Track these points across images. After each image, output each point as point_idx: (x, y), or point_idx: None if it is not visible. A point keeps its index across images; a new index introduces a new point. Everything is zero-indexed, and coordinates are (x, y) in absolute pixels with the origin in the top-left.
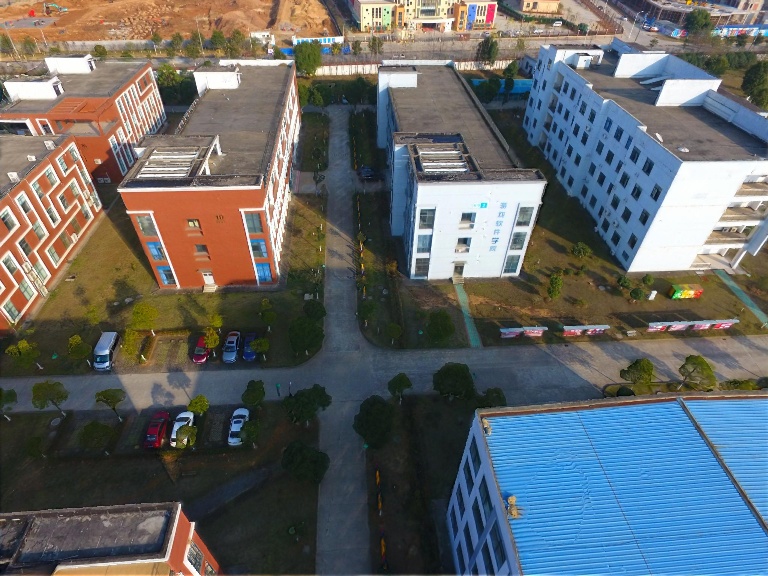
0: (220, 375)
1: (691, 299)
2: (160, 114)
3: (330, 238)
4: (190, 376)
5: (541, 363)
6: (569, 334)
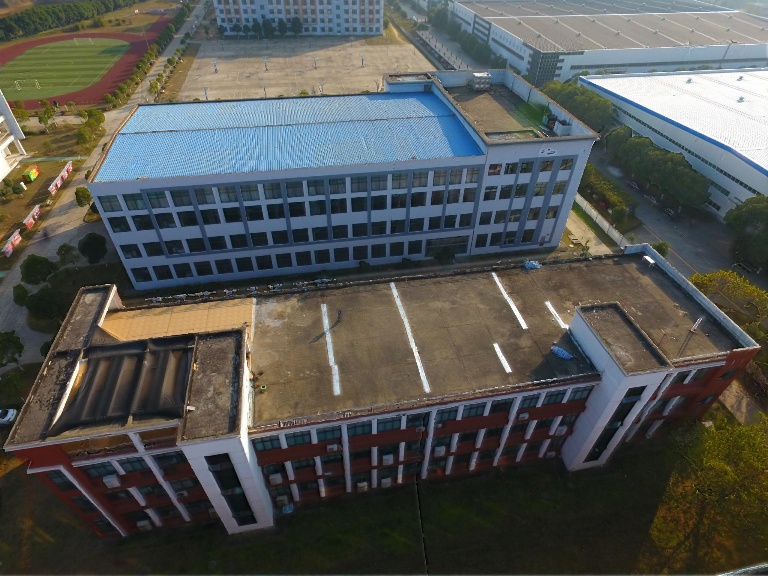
0: None
1: (39, 175)
2: None
3: None
4: None
5: (46, 244)
6: (30, 226)
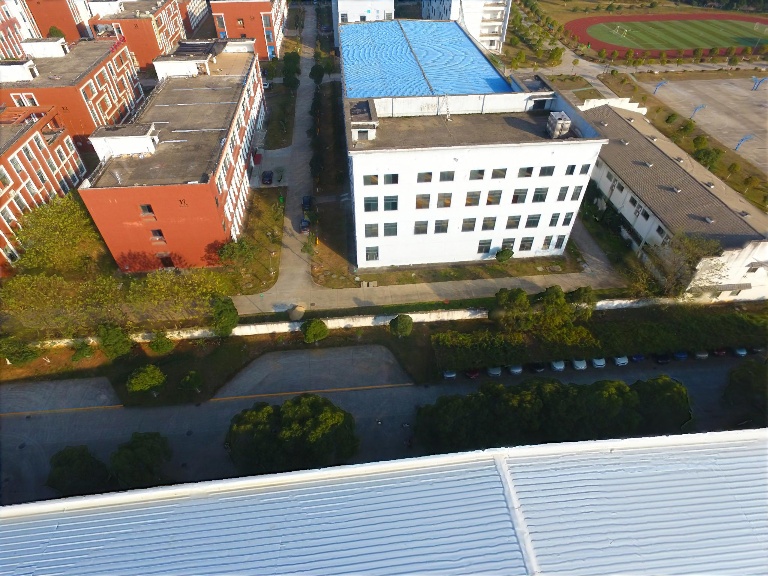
0: None
1: None
2: (205, 6)
3: (303, 49)
4: None
5: None
6: None
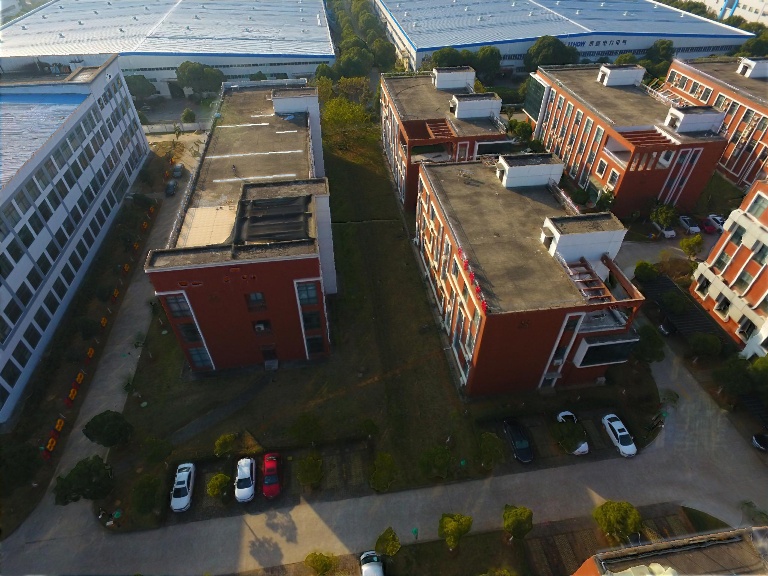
0: (211, 567)
1: None
2: None
3: None
4: (252, 561)
5: None
6: None
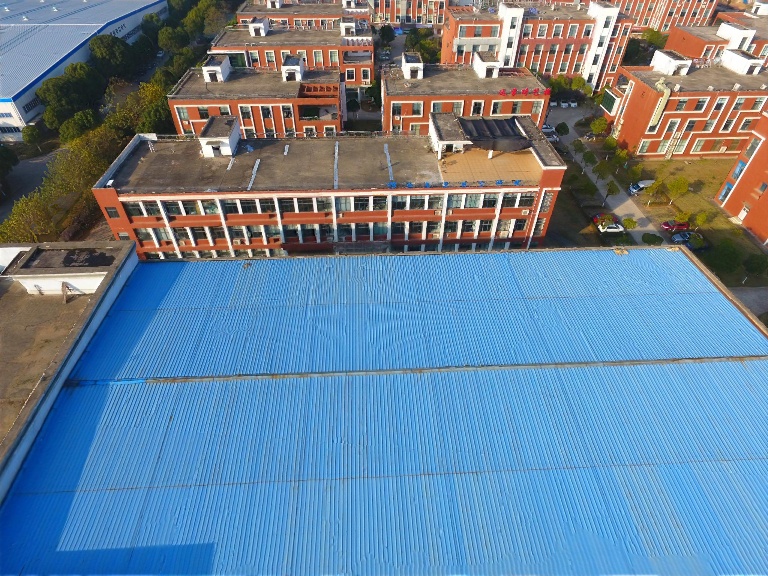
0: None
1: None
2: None
3: None
4: (649, 226)
5: None
6: None
